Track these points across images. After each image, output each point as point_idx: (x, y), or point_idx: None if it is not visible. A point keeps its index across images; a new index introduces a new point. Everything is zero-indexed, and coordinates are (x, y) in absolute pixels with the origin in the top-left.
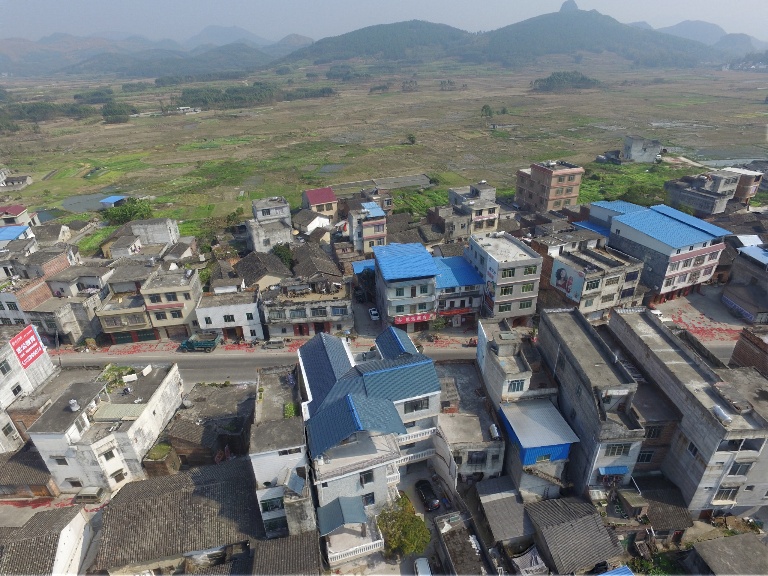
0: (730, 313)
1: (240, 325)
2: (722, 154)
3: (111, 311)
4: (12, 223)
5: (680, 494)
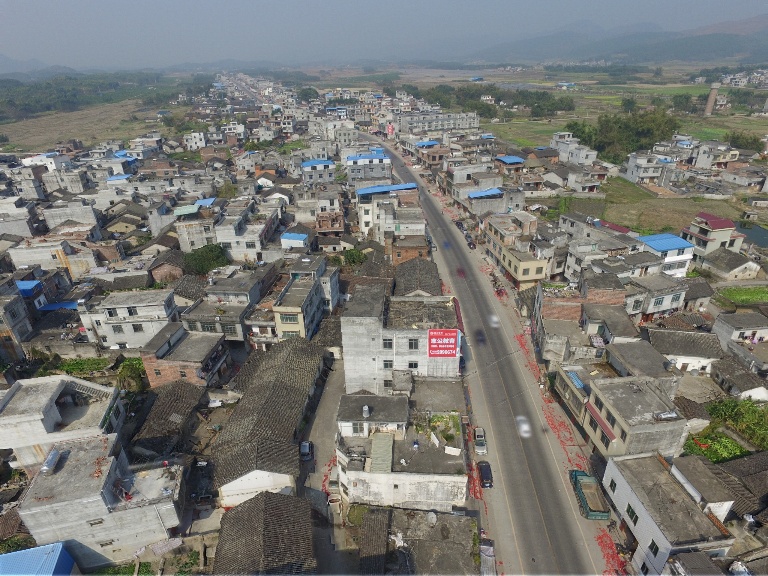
0: None
1: (638, 539)
2: None
3: (564, 374)
4: (704, 235)
5: None
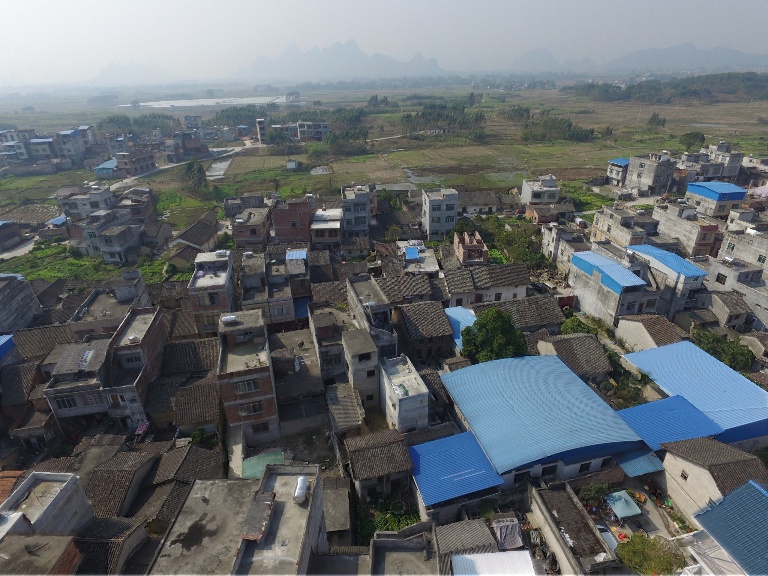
0: None
1: None
2: None
3: None
4: None
5: None
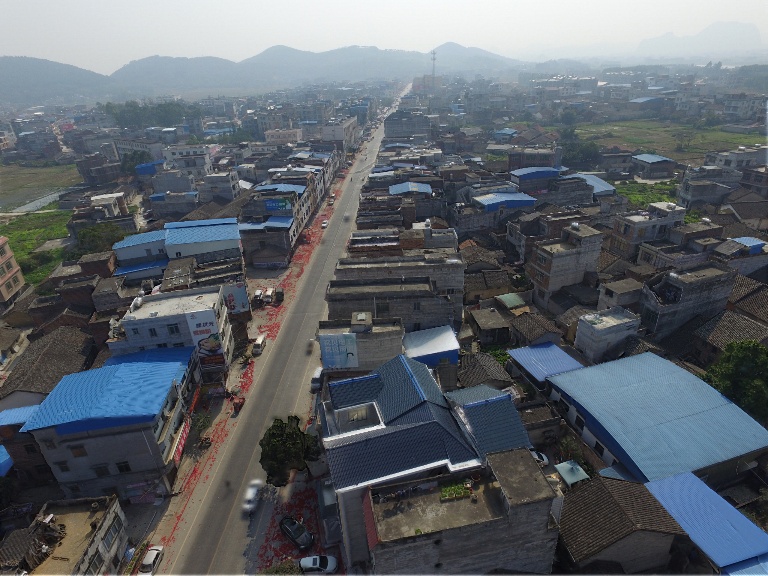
0: (271, 270)
1: None
2: (14, 201)
3: None
4: None
5: (455, 320)
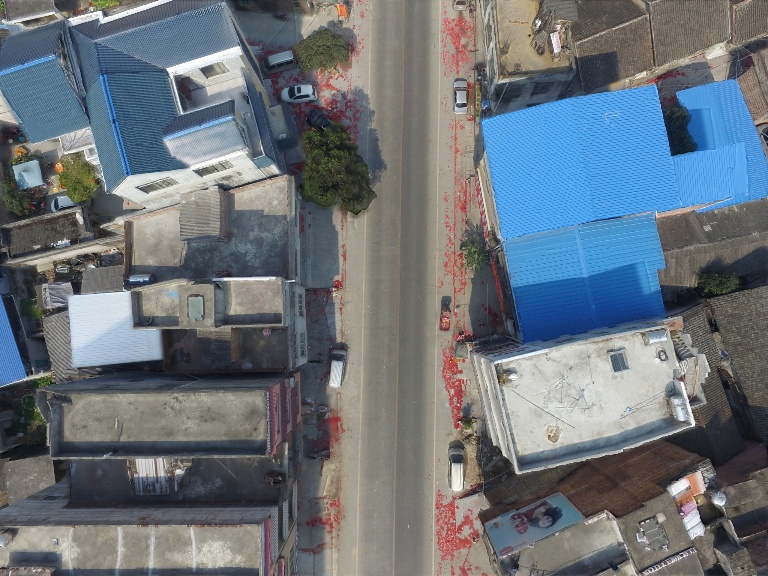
0: None
1: None
2: None
3: None
4: None
5: None
